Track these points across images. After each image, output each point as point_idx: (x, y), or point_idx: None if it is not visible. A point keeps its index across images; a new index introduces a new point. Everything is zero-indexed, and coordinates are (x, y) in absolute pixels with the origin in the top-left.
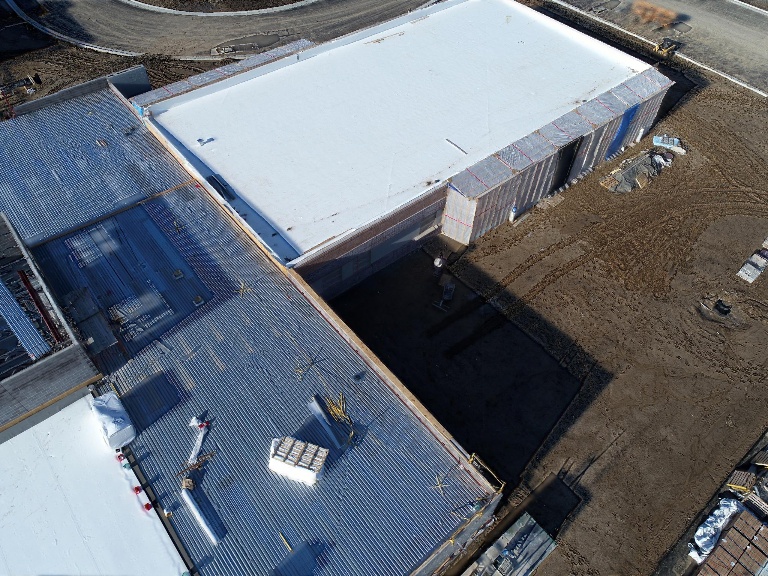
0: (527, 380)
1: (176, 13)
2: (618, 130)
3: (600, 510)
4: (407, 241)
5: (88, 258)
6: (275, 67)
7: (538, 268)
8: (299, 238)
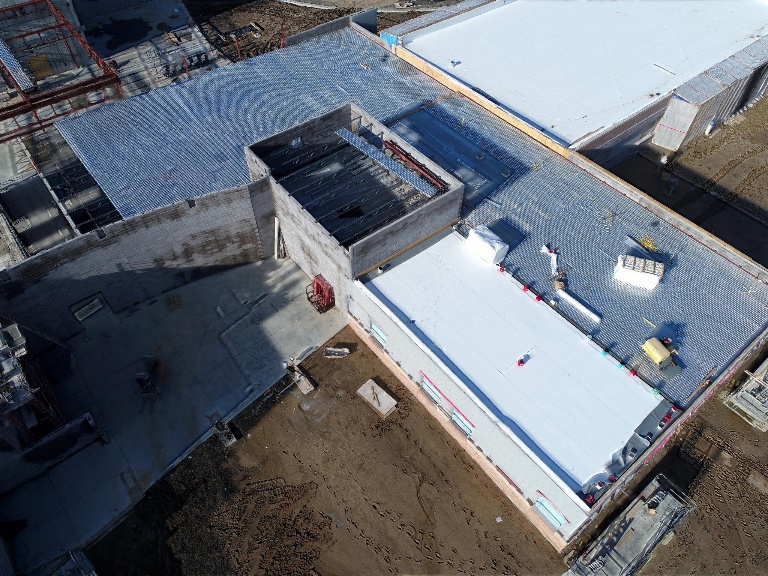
0: (758, 246)
1: None
2: None
3: None
4: (630, 145)
5: None
6: (488, 9)
7: (741, 168)
8: (564, 133)
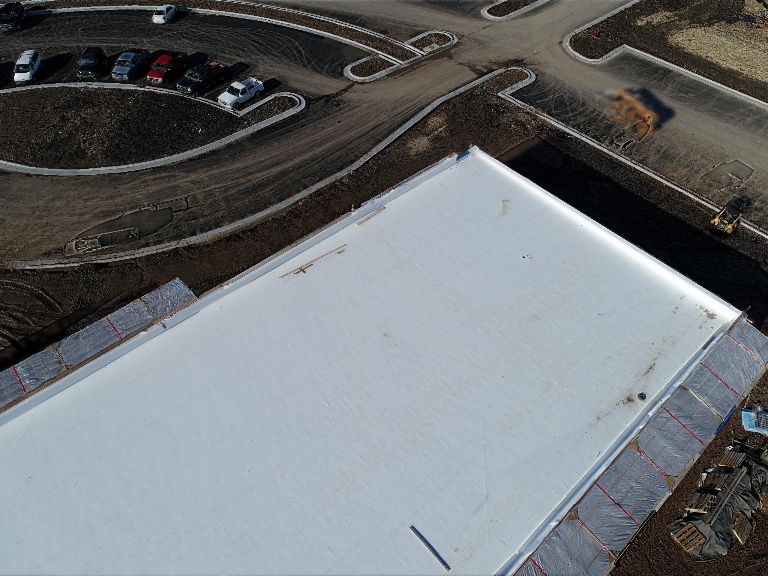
0: None
1: (29, 172)
2: None
3: None
4: None
5: None
6: (123, 351)
7: None
8: None
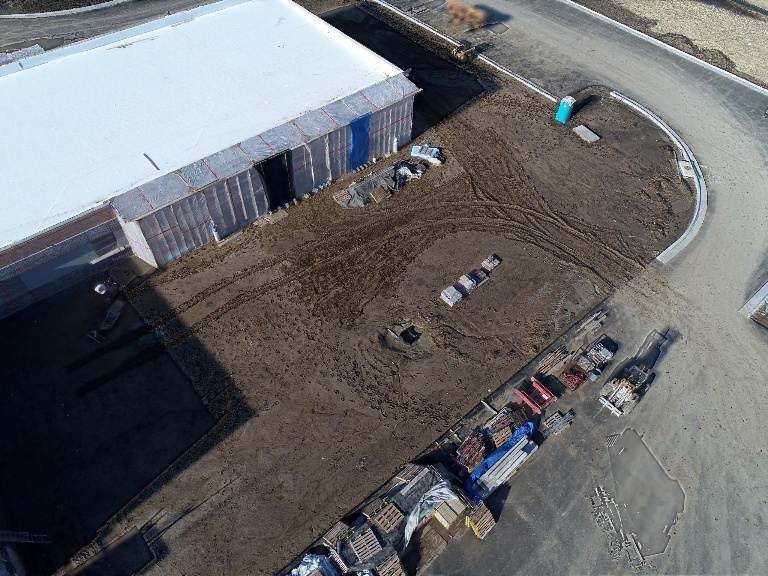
0: (156, 420)
1: None
2: (352, 141)
3: (169, 570)
4: (82, 265)
5: None
6: None
7: (224, 293)
8: None
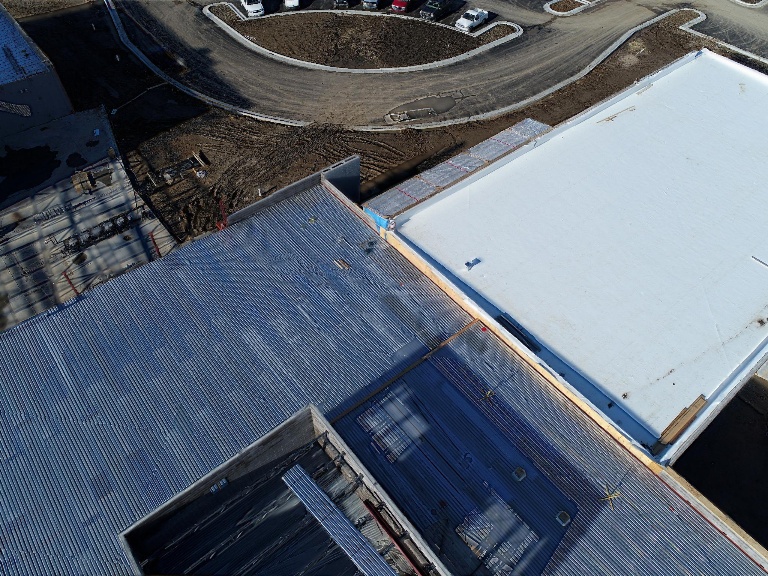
0: None
1: (329, 70)
2: None
3: None
4: None
5: (395, 447)
6: (512, 157)
7: None
8: (644, 411)
